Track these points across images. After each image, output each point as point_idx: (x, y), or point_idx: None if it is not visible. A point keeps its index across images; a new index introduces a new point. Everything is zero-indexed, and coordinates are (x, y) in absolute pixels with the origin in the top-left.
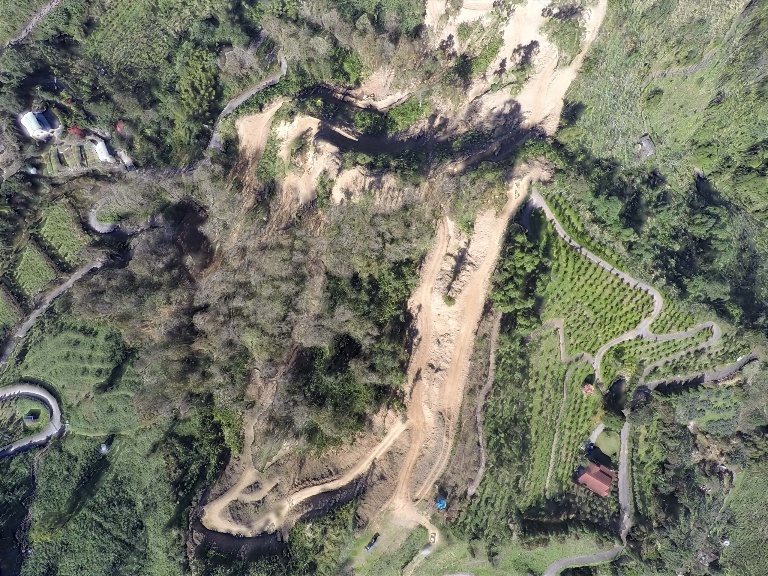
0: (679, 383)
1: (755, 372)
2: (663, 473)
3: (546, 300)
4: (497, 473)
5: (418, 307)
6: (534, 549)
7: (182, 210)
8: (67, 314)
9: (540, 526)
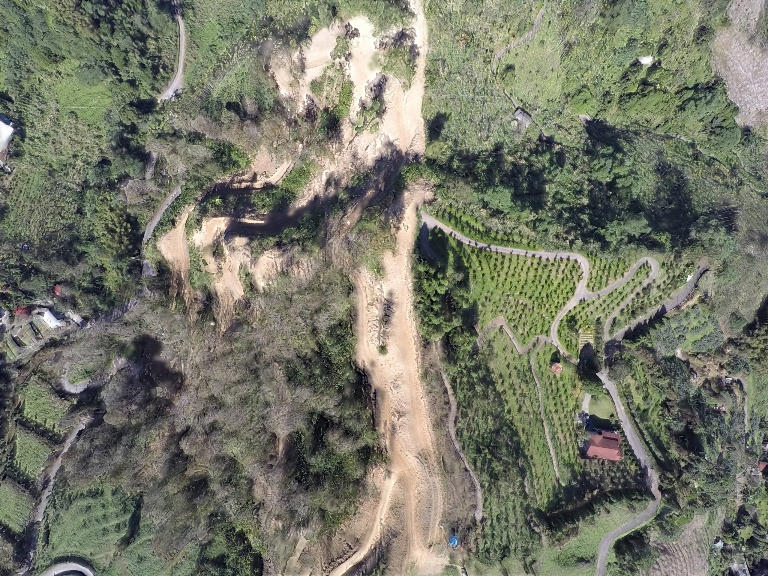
0: (644, 323)
1: (711, 282)
2: (668, 412)
3: (476, 307)
4: (496, 489)
5: (362, 364)
6: (571, 539)
7: (140, 343)
8: (68, 487)
9: (566, 516)
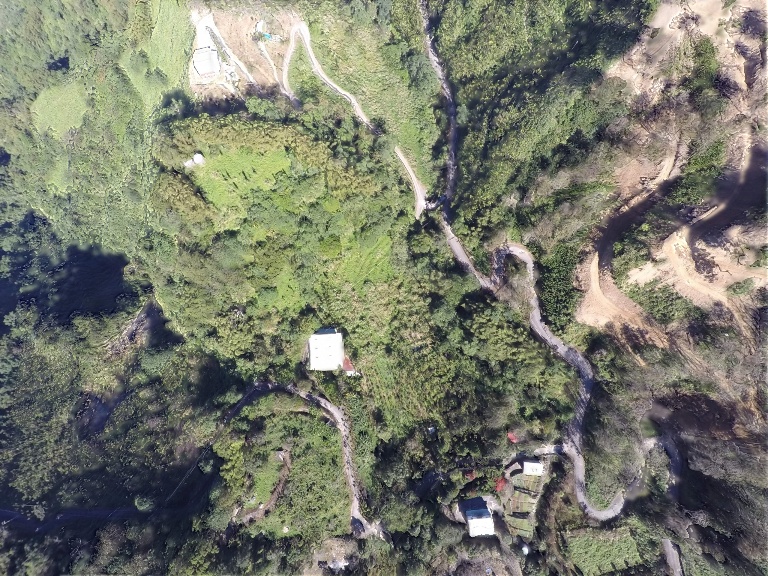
0: None
1: None
2: None
3: None
4: None
5: None
6: None
7: None
8: None
9: None
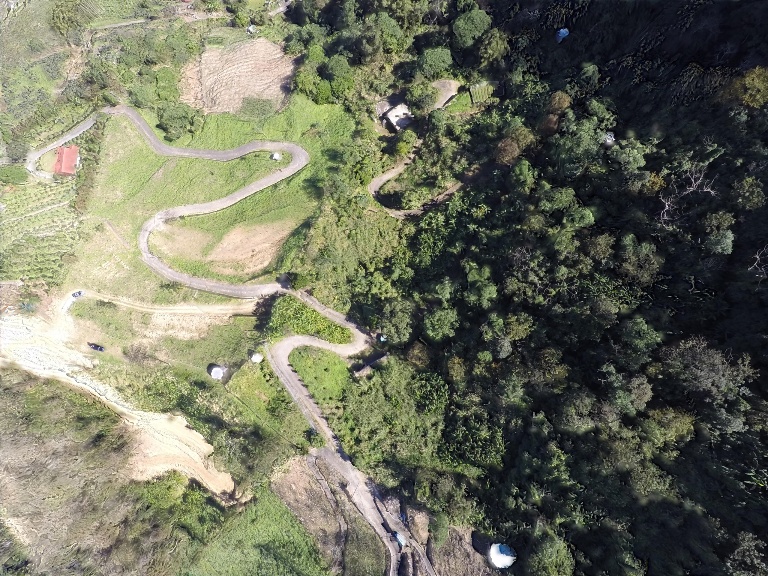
0: None
1: None
2: None
3: None
4: None
5: None
6: (114, 188)
7: None
8: None
9: None
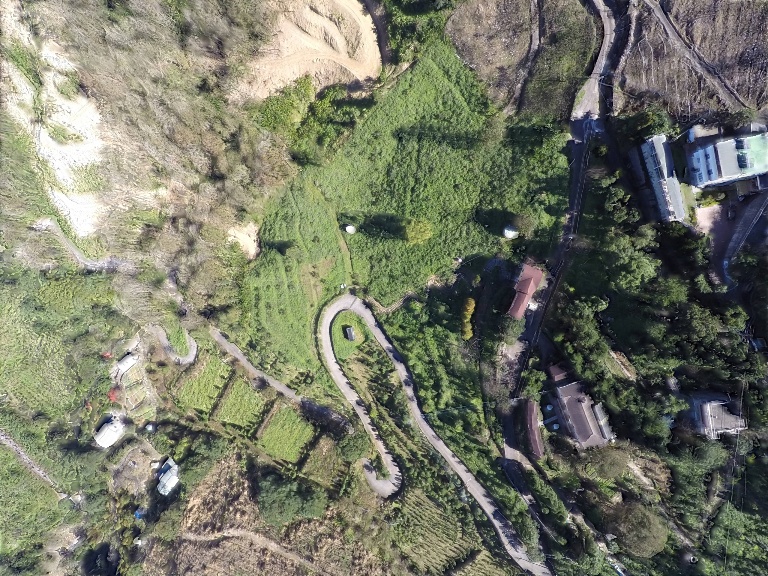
0: None
1: None
2: None
3: None
4: None
5: None
6: None
7: None
8: (231, 310)
9: None
